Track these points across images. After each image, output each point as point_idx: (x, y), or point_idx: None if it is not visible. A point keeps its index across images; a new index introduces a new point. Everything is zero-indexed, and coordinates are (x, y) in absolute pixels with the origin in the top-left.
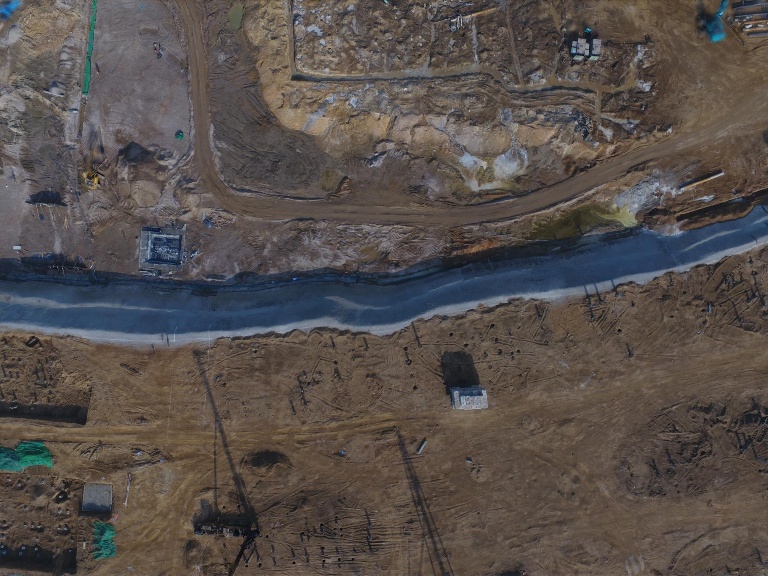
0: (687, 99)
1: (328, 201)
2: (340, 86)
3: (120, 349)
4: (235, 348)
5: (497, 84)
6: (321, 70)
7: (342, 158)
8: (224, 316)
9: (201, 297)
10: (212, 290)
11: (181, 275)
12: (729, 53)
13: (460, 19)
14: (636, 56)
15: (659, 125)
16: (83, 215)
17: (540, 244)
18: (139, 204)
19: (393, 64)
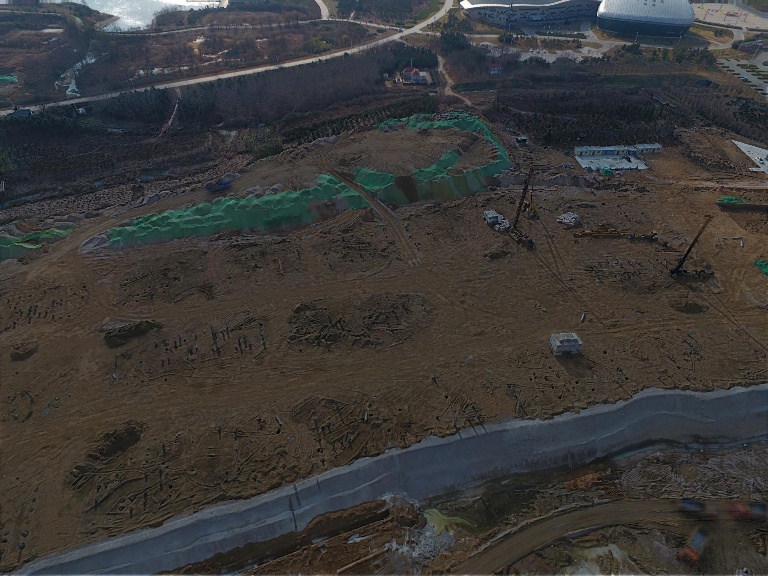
0: None
1: (766, 524)
2: None
3: None
4: (767, 376)
5: None
6: None
7: None
8: None
9: None
10: None
11: None
12: None
13: None
14: None
15: None
16: None
17: (523, 487)
18: None
19: None
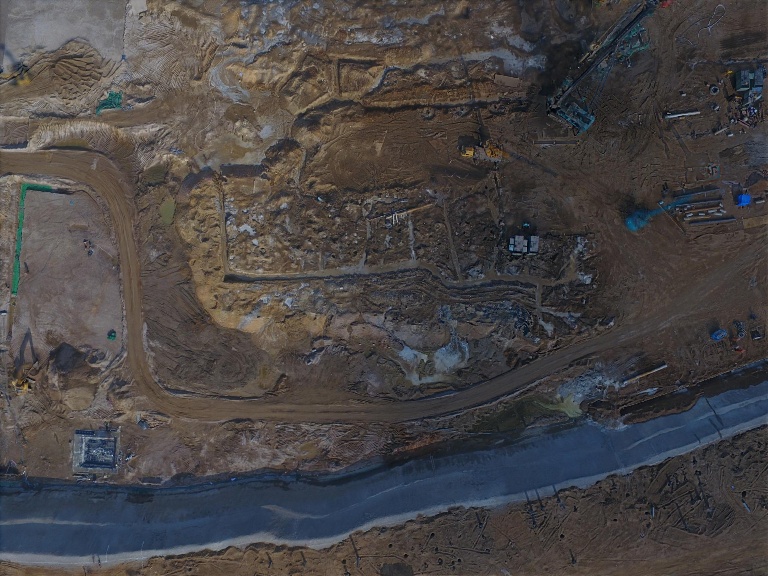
0: (629, 290)
1: (265, 400)
2: (274, 286)
3: (50, 572)
4: (169, 566)
5: (435, 281)
6: (254, 270)
7: (279, 355)
8: (158, 529)
9: (136, 505)
10: (149, 493)
11: (116, 479)
12: (671, 242)
13: (395, 216)
14: (576, 248)
15: (601, 318)
16: (14, 419)
17: (483, 437)
18: (71, 408)
19: (328, 262)
